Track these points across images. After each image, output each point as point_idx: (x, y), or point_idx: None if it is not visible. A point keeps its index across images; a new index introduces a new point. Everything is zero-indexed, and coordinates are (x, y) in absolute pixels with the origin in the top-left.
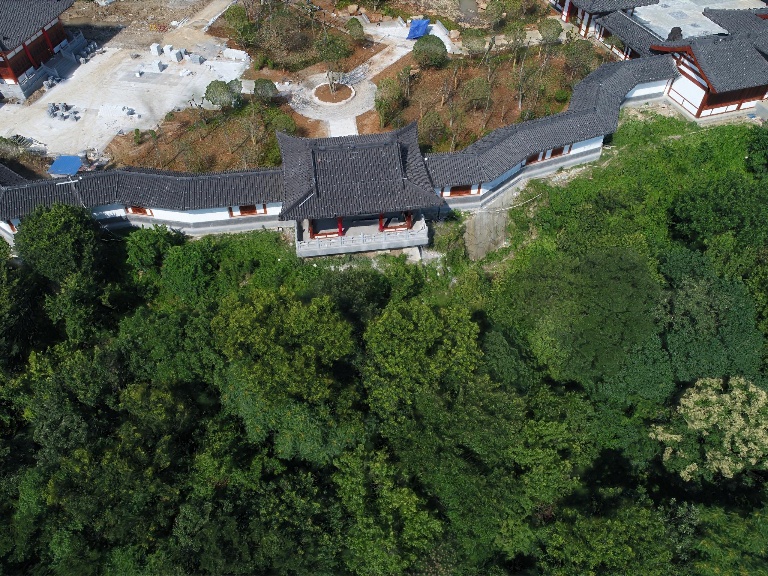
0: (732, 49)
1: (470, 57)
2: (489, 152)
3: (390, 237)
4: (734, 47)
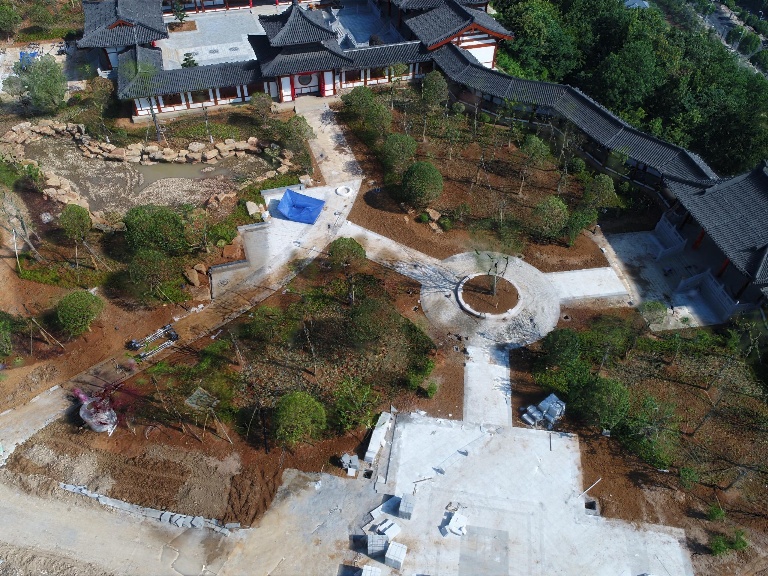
0: None
1: None
2: None
3: None
4: None
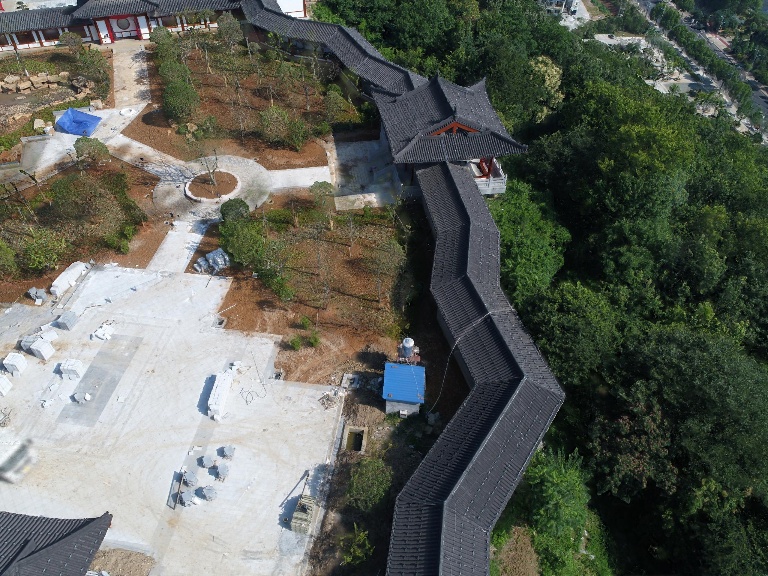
0: None
1: None
2: None
3: None
4: None
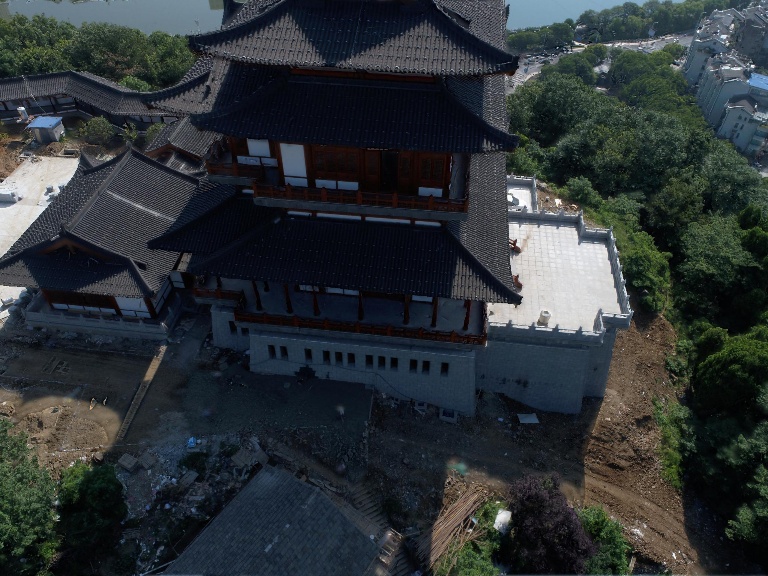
0: None
1: None
2: None
3: None
4: None
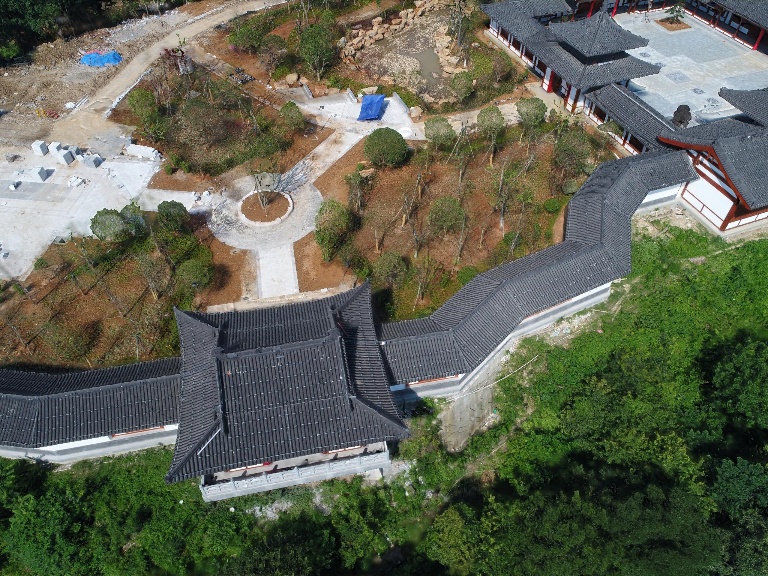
0: (763, 147)
1: (436, 148)
2: (468, 323)
3: (337, 466)
4: (765, 144)
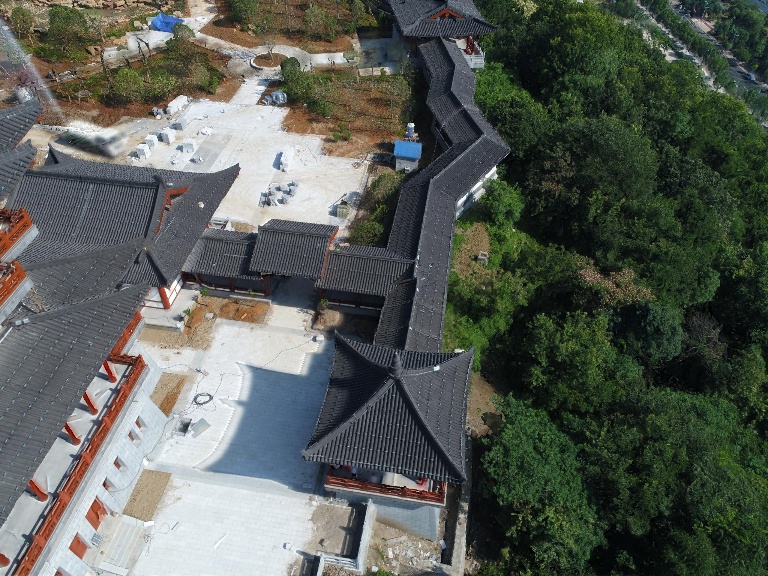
0: None
1: None
2: None
3: None
4: None
